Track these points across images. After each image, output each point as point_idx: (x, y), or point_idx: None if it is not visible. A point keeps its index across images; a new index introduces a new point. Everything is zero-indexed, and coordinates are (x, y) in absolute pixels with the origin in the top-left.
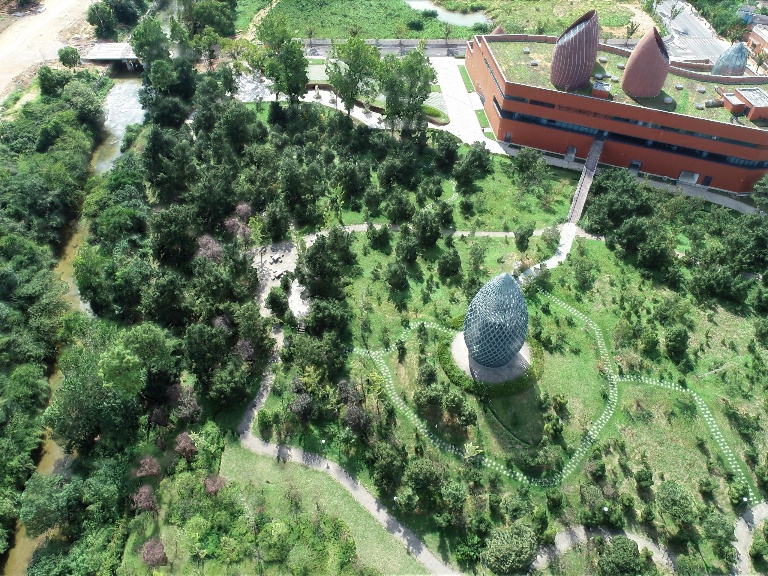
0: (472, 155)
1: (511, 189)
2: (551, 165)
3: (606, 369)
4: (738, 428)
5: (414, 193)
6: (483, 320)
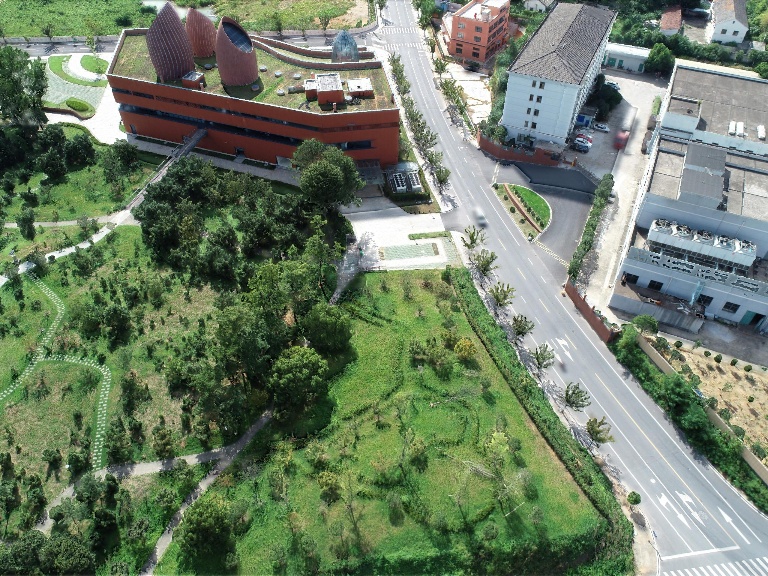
0: (66, 148)
1: (99, 180)
2: (161, 155)
3: (37, 350)
4: None
5: None
6: None
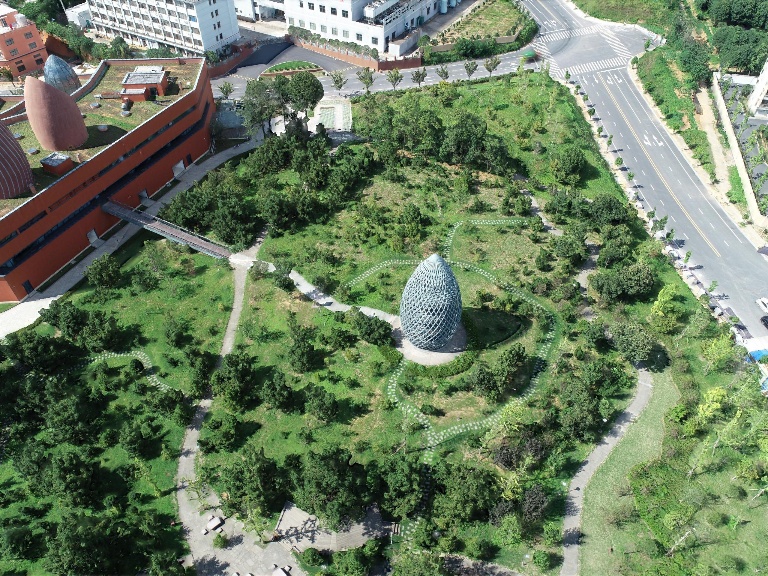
0: (73, 319)
1: (144, 299)
2: None
3: None
4: (484, 211)
5: (115, 400)
6: (453, 302)
